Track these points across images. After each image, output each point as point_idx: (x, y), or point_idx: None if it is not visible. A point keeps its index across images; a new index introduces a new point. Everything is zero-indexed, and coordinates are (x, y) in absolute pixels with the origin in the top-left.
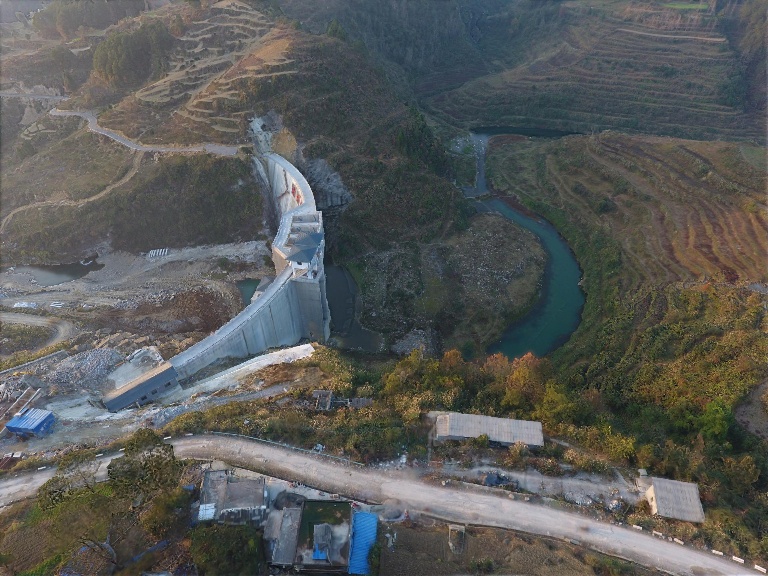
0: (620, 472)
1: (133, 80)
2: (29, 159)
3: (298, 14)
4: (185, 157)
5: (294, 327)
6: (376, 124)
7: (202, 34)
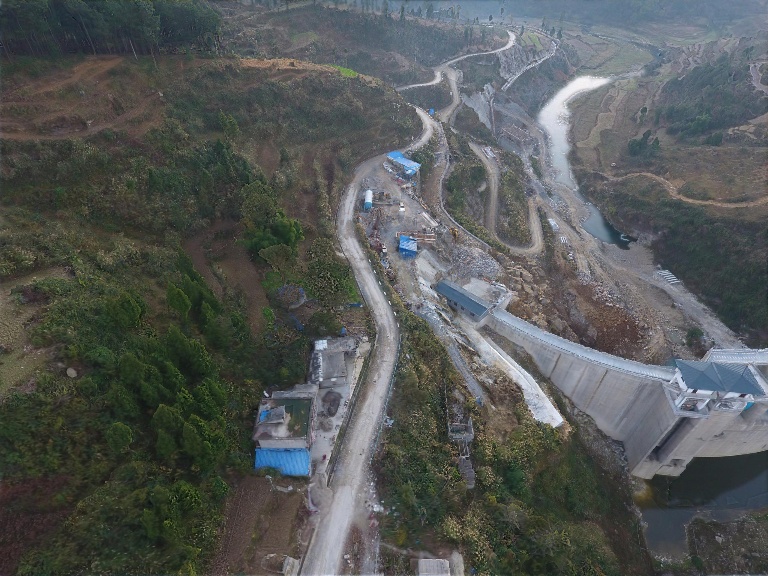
0: None
1: None
2: (705, 146)
3: None
4: None
5: (622, 422)
6: None
7: None
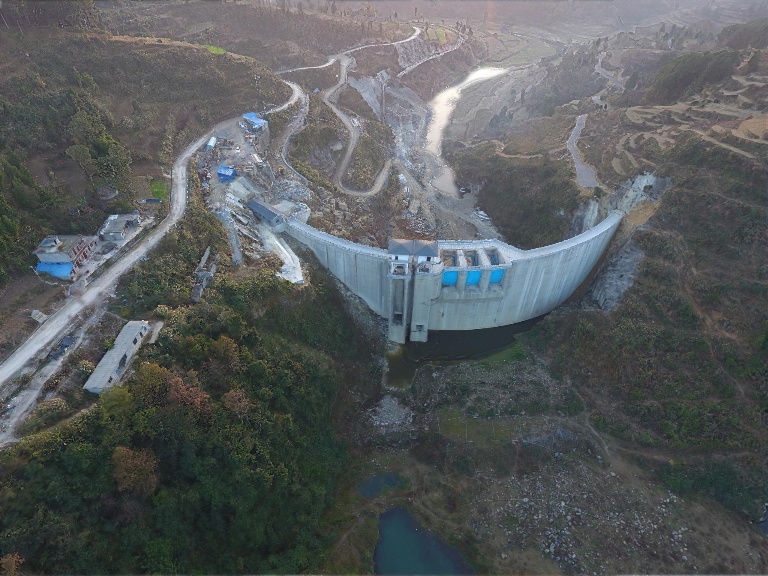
0: None
1: (661, 98)
2: (539, 117)
3: None
4: (564, 166)
5: (383, 301)
6: None
7: (760, 80)
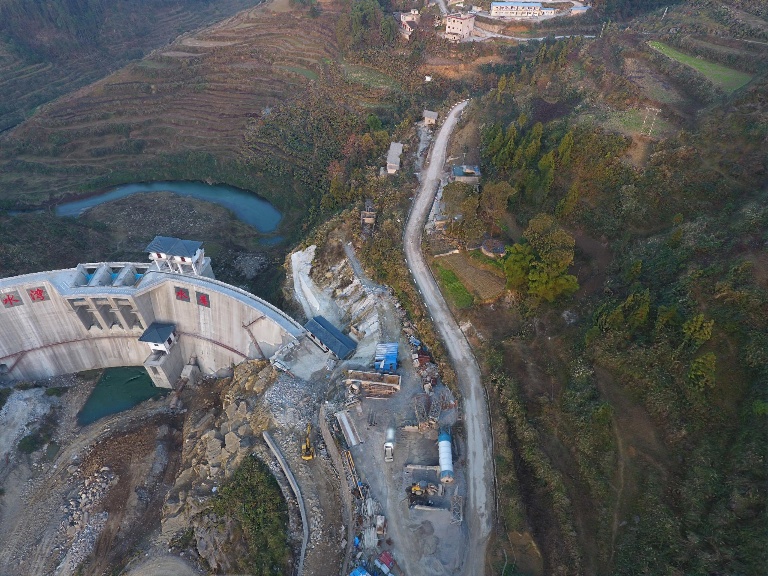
0: None
1: None
2: None
3: None
4: None
5: None
6: None
7: None
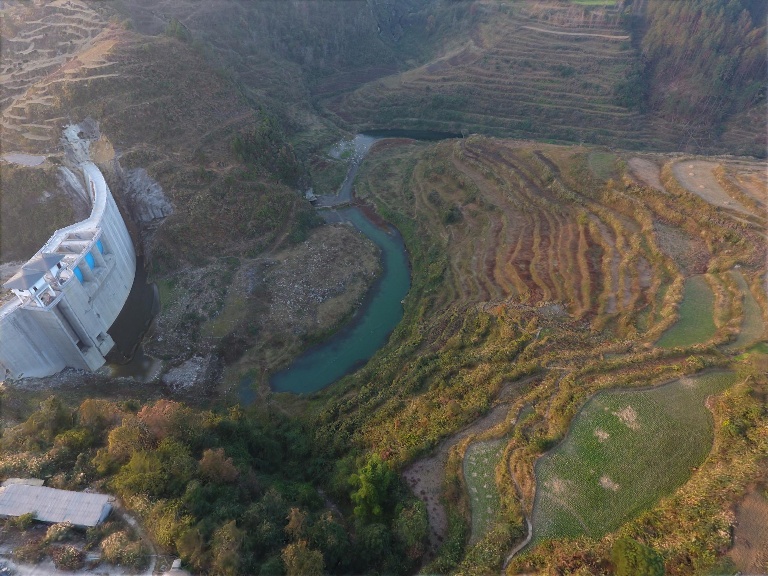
0: (156, 562)
1: None
2: None
3: (177, 12)
4: None
5: (45, 357)
6: (211, 130)
7: (34, 35)
